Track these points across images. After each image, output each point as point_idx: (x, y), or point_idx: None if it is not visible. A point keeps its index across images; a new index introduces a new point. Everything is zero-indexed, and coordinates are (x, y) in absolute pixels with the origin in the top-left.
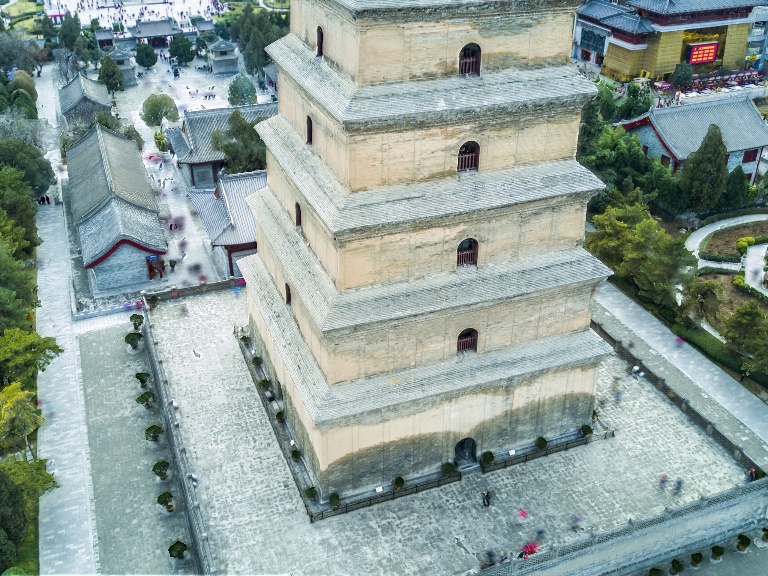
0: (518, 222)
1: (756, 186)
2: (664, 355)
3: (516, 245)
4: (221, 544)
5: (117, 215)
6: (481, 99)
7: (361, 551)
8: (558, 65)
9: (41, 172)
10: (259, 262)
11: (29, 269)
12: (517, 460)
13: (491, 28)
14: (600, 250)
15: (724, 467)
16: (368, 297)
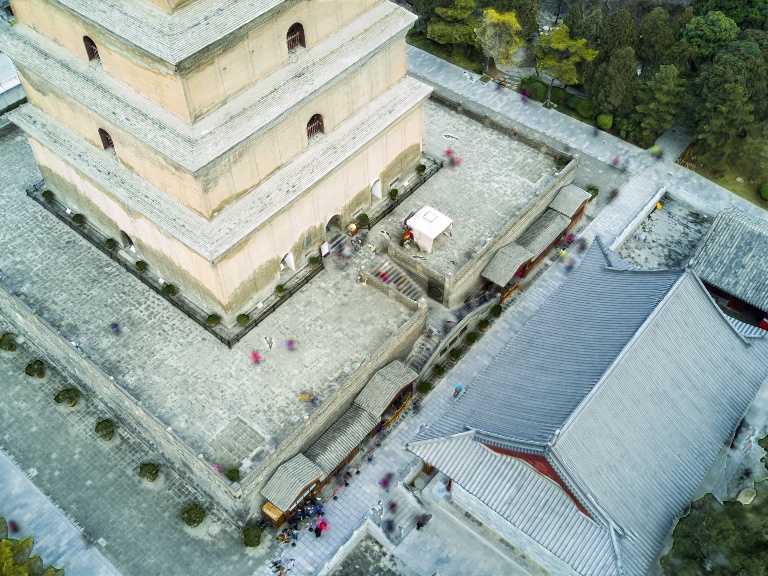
0: None
1: None
2: None
3: None
4: None
5: None
6: None
7: None
8: None
9: None
10: None
11: None
12: None
13: None
14: None
15: None
16: None
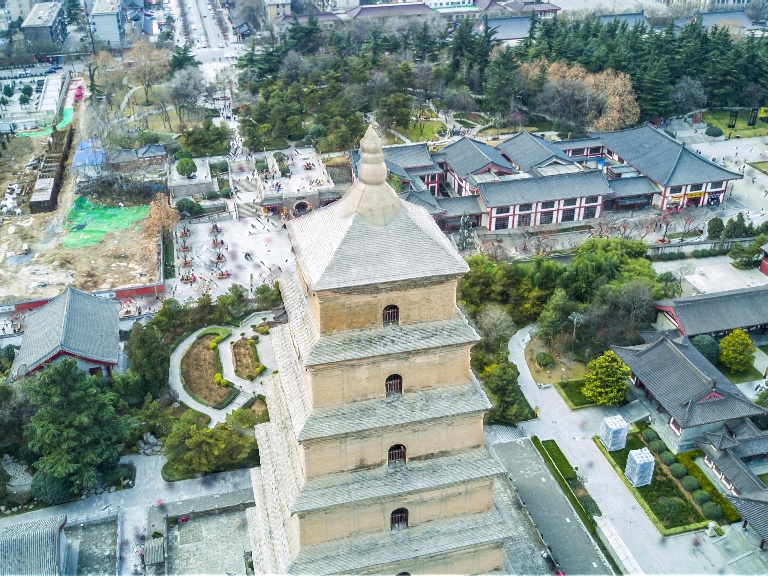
0: None
1: None
2: None
3: None
4: None
5: None
6: None
7: None
8: None
9: None
10: None
11: None
12: None
13: None
14: (214, 458)
15: None
16: None
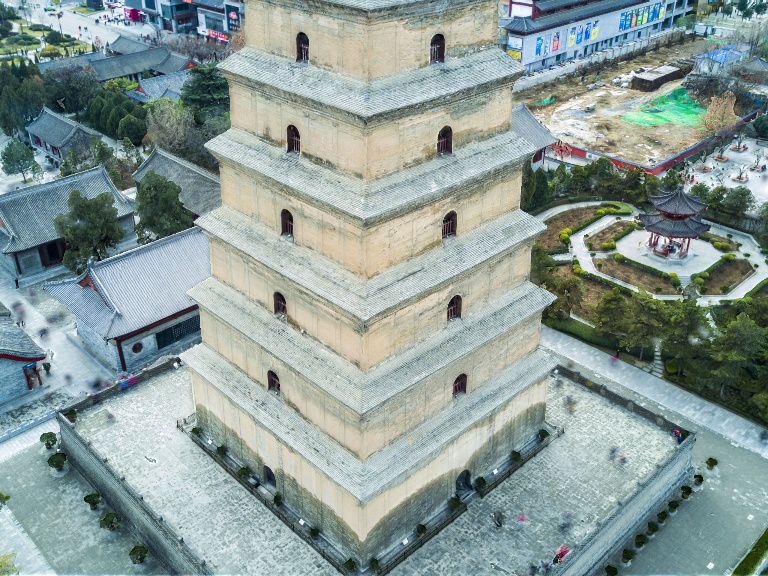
0: (488, 272)
1: (551, 182)
2: (551, 348)
3: (487, 292)
4: None
5: None
6: (460, 174)
7: None
8: (504, 132)
9: None
10: (210, 353)
11: None
12: (503, 477)
13: (459, 111)
14: None
15: (654, 435)
16: (388, 370)
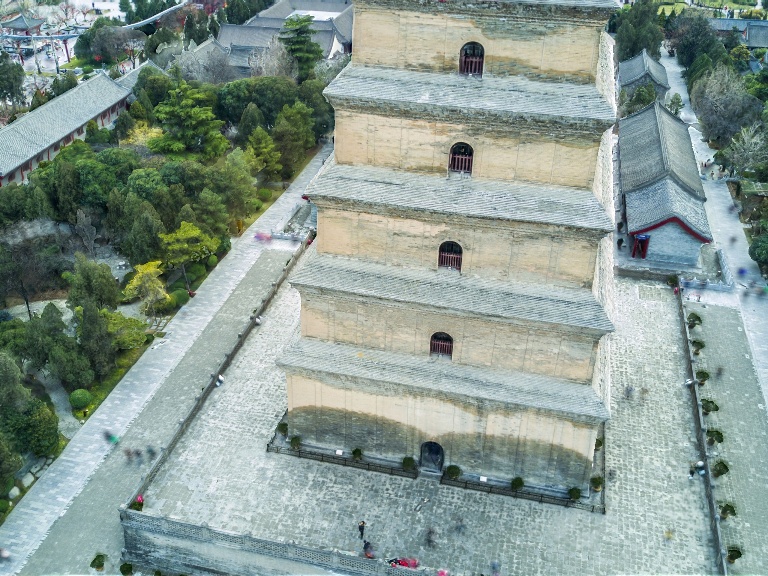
0: (509, 240)
1: None
2: None
3: (507, 264)
4: (195, 434)
5: None
6: (470, 101)
7: (282, 491)
8: (578, 83)
9: (331, 113)
10: None
11: (279, 189)
12: (480, 487)
13: (496, 30)
14: None
15: None
16: (342, 266)
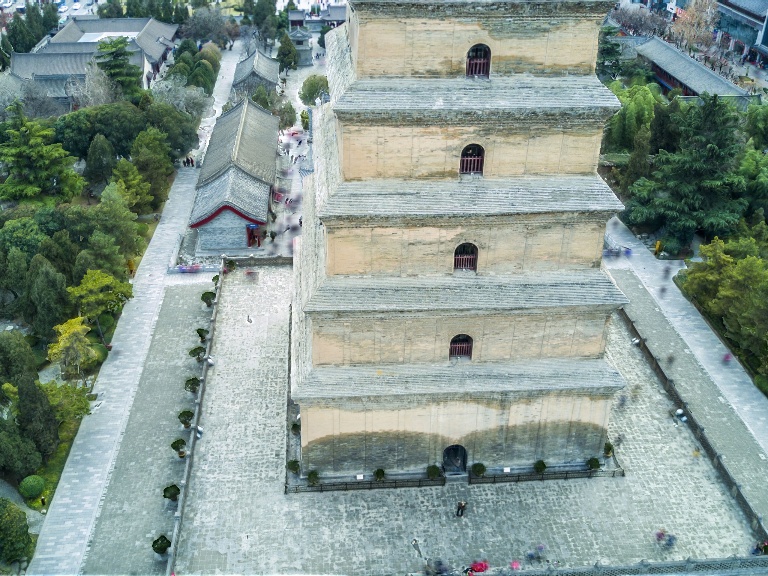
0: (524, 233)
1: None
2: (733, 405)
3: (521, 257)
4: (199, 494)
5: (229, 183)
6: (484, 102)
7: (319, 530)
8: (580, 74)
9: (184, 136)
10: None
11: (152, 222)
12: (508, 478)
13: (503, 30)
14: (698, 282)
15: (735, 534)
16: (356, 286)
